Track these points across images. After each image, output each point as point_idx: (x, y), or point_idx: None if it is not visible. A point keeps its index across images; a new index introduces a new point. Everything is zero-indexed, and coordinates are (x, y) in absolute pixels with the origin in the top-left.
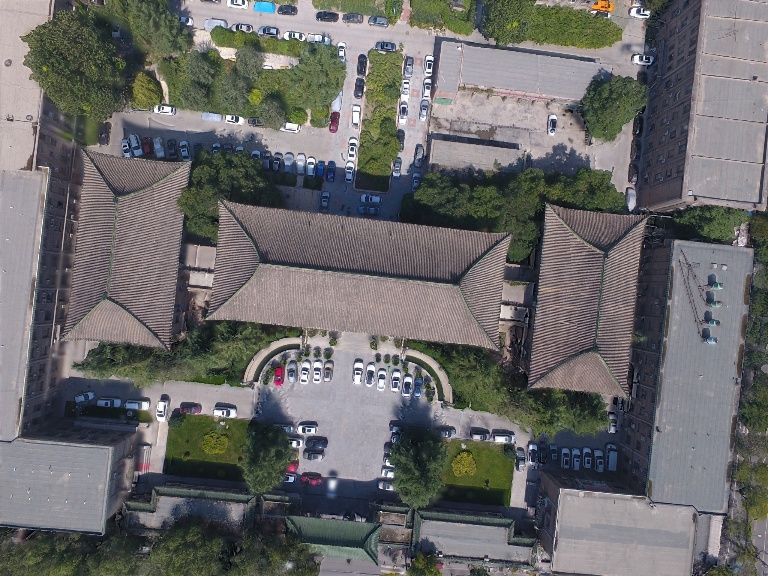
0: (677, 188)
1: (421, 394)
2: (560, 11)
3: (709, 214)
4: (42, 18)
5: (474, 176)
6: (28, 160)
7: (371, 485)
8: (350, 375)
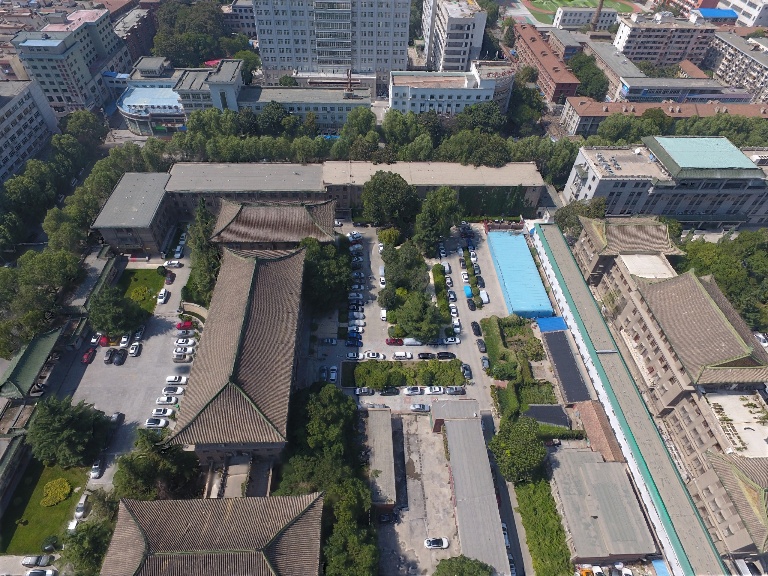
0: None
1: None
2: (554, 520)
3: None
4: (410, 182)
5: (361, 451)
6: (329, 183)
7: None
8: None
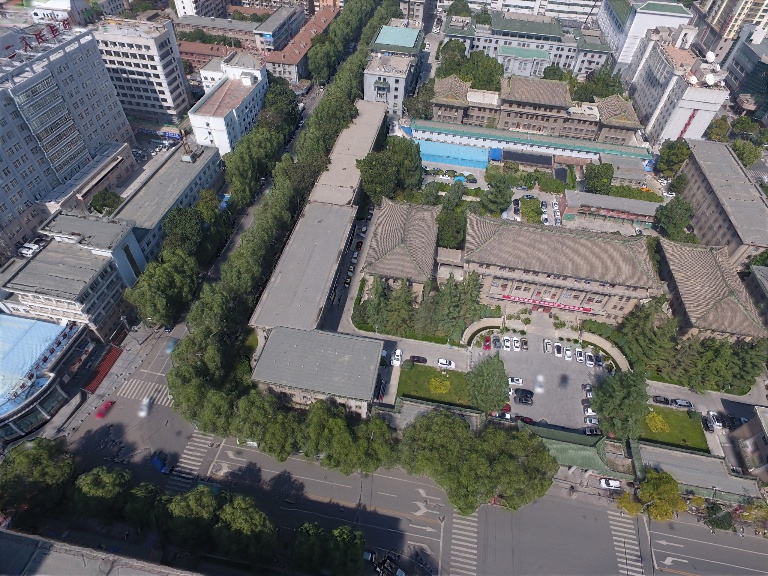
0: (737, 242)
1: (602, 367)
2: (625, 186)
3: (766, 254)
4: None
5: None
6: (349, 201)
7: (578, 432)
8: (542, 349)
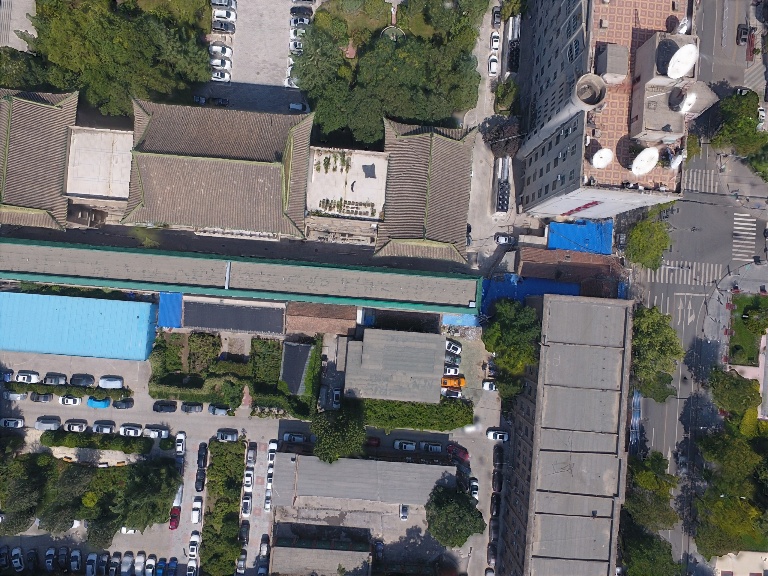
0: None
1: None
2: (403, 405)
3: None
4: None
5: None
6: None
7: None
8: None
